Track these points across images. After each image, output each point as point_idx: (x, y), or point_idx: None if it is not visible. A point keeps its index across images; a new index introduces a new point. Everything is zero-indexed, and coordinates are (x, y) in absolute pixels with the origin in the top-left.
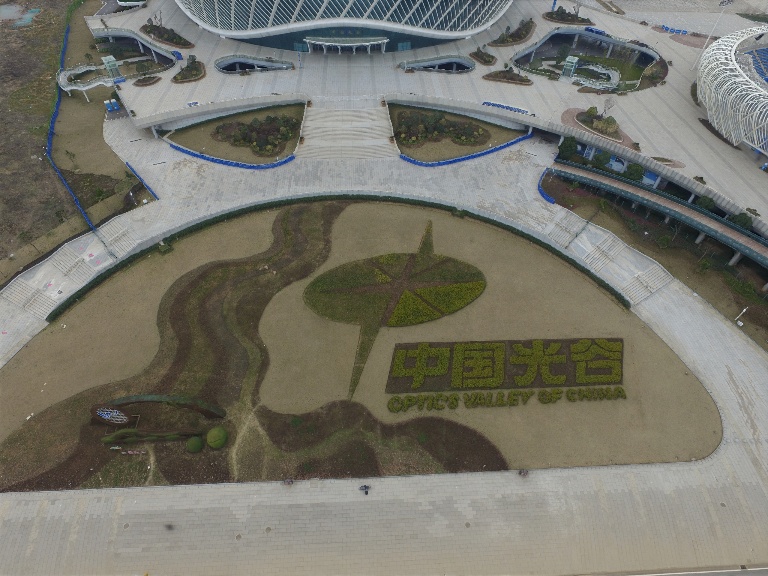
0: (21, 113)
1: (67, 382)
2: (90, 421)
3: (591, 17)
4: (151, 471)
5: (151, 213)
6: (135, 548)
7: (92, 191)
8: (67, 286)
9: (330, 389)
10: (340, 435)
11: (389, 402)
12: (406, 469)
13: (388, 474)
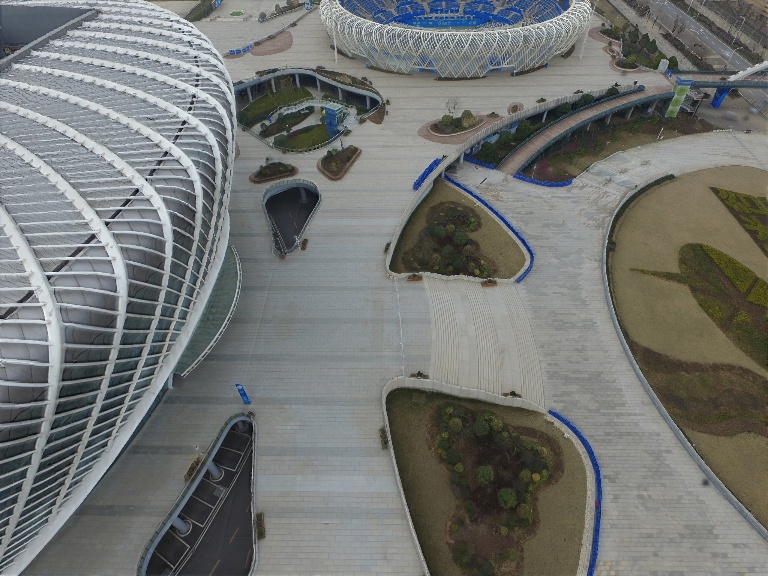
0: None
1: None
2: None
3: None
4: None
5: None
6: None
7: None
8: None
9: None
10: None
11: None
12: None
13: None
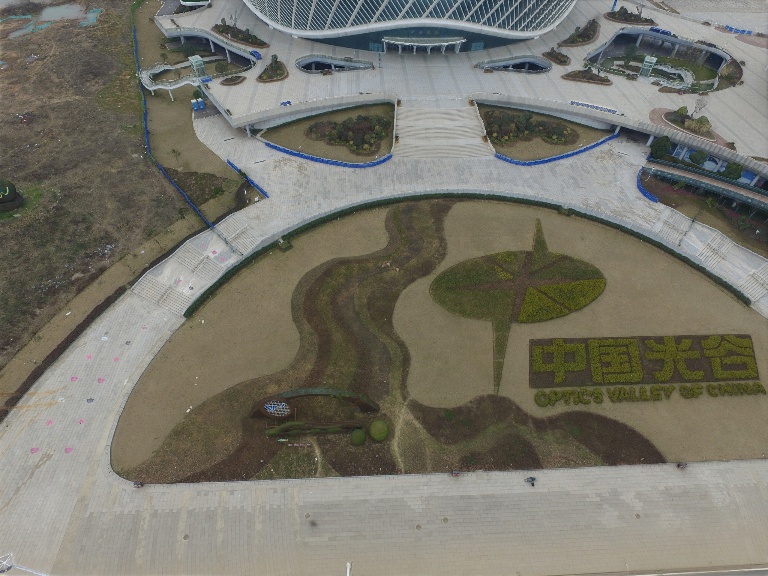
0: (111, 112)
1: (218, 376)
2: (251, 414)
3: (652, 17)
4: (319, 463)
5: (264, 211)
6: (321, 537)
7: (200, 189)
8: (197, 282)
9: (475, 384)
10: (495, 428)
11: (536, 396)
12: (566, 462)
13: (550, 466)
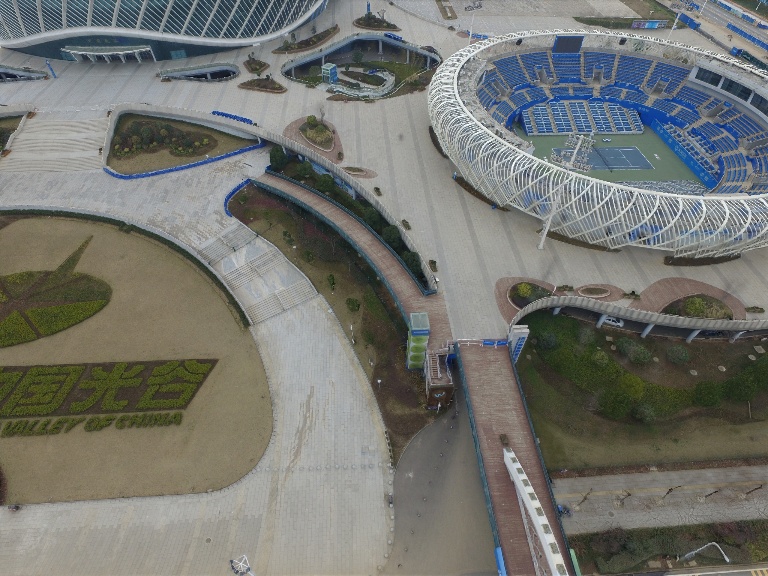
0: None
1: None
2: None
3: (403, 22)
4: None
5: None
6: None
7: None
8: None
9: None
10: None
11: None
12: None
13: None
